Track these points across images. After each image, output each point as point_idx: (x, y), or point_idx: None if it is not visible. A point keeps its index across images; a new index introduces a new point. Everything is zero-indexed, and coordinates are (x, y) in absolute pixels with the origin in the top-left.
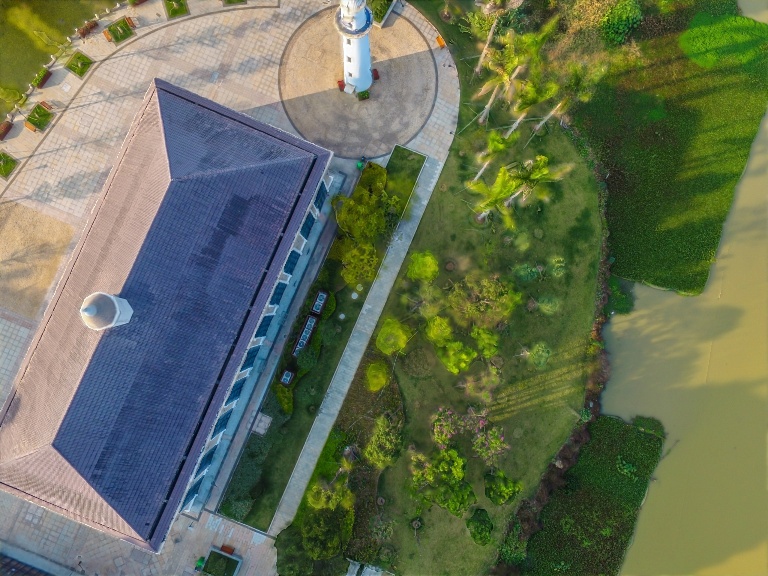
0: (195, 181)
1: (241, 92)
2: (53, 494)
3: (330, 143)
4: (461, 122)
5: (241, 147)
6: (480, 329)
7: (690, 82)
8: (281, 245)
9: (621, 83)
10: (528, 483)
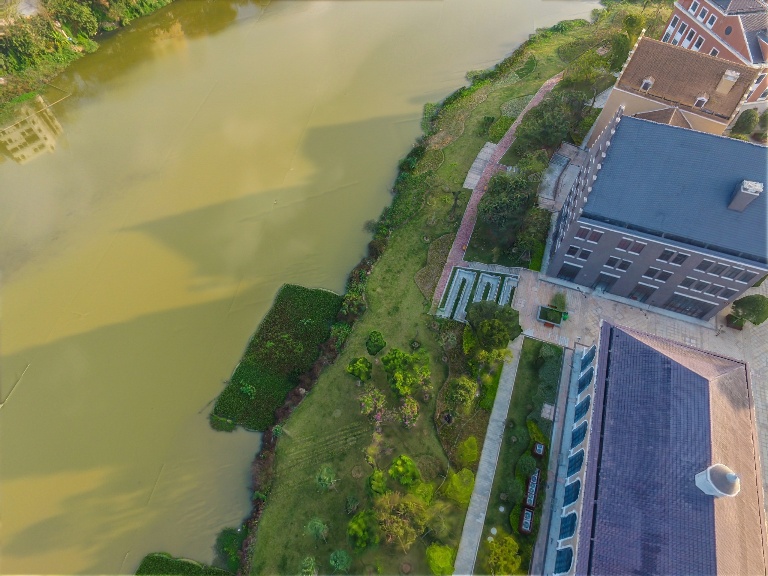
0: None
1: None
2: (689, 352)
3: None
4: None
5: None
6: (384, 497)
7: None
8: (586, 568)
9: None
10: (329, 376)
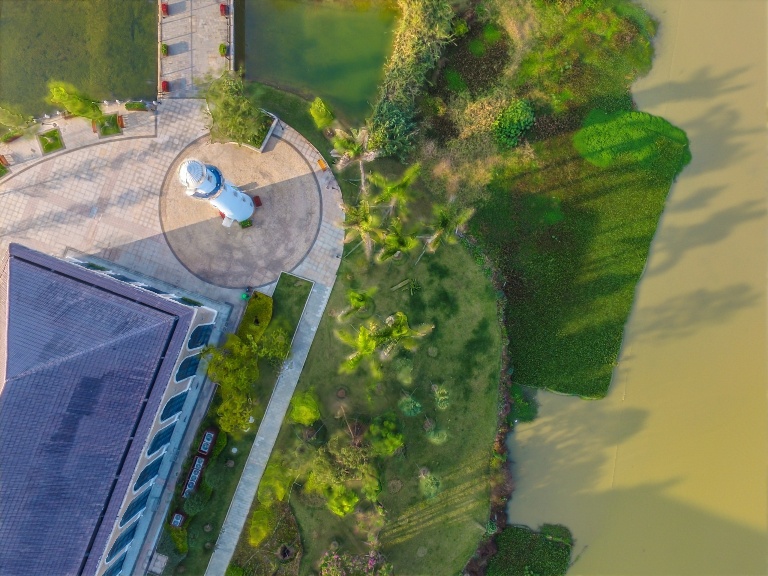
0: (35, 375)
1: (122, 226)
2: None
3: (215, 273)
4: (347, 245)
5: (93, 322)
6: None
7: (586, 182)
8: (146, 410)
9: (516, 187)
10: None
